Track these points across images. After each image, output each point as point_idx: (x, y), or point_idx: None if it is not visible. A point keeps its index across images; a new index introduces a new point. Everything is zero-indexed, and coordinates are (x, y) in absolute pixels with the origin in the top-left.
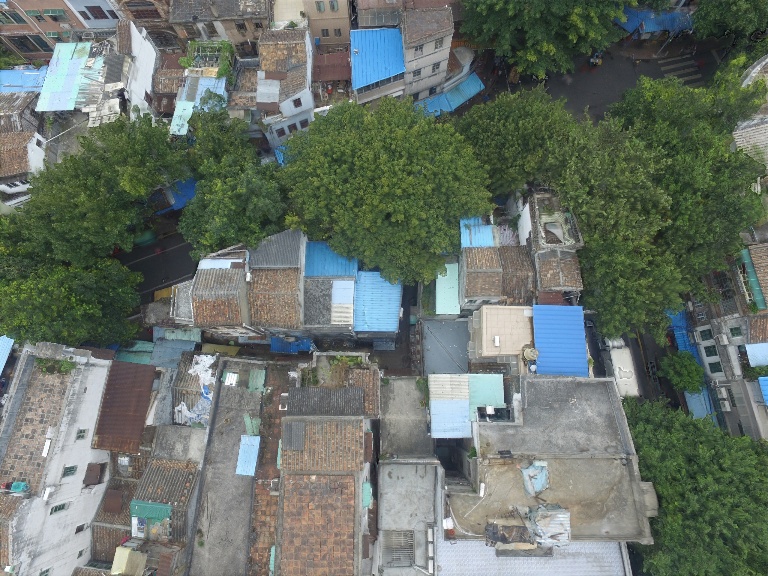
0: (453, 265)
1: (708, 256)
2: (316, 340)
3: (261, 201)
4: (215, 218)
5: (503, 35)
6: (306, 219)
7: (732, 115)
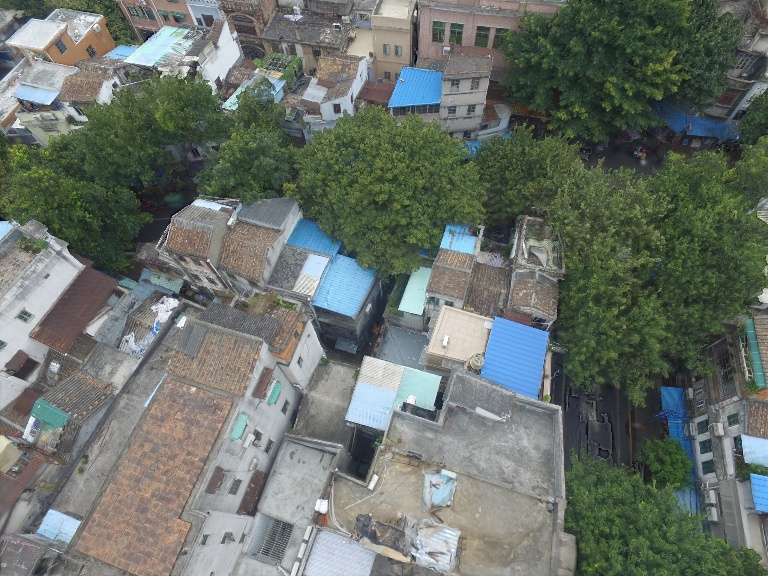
0: (430, 269)
1: (702, 314)
2: None
3: (266, 159)
4: None
5: (538, 91)
6: (304, 193)
7: (755, 189)
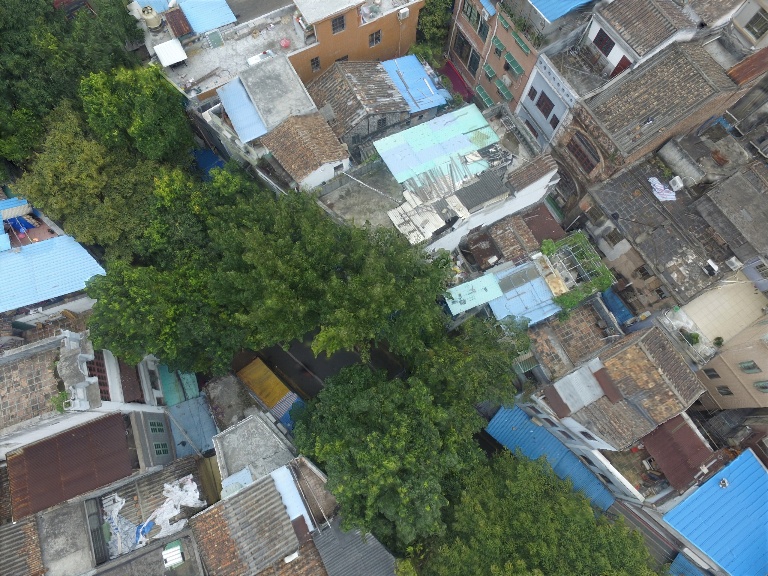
0: None
1: None
2: None
3: (405, 529)
4: (344, 478)
5: None
6: None
7: None
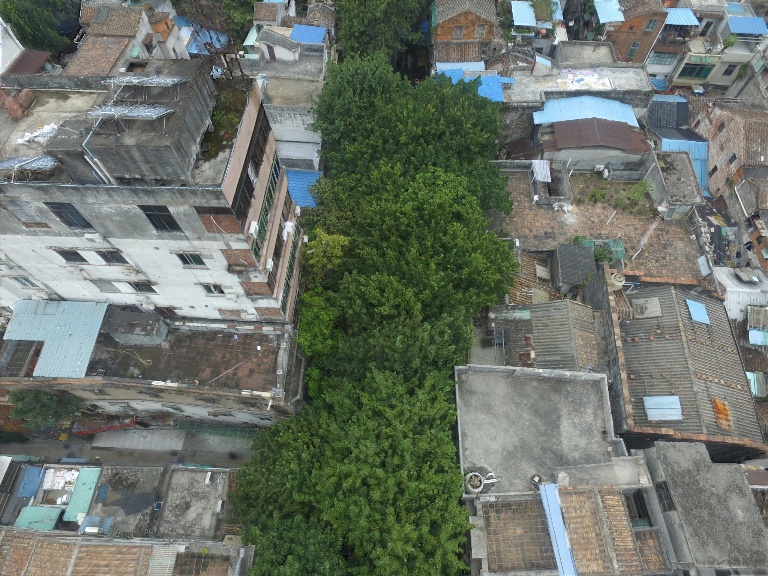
0: None
1: None
2: None
3: None
4: None
5: None
6: None
7: None
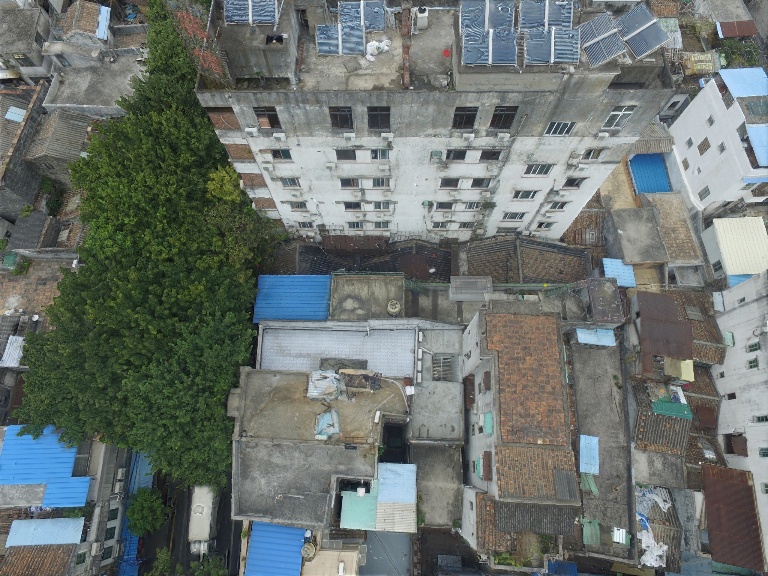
0: None
1: None
2: (527, 574)
3: None
4: None
5: None
6: None
7: None
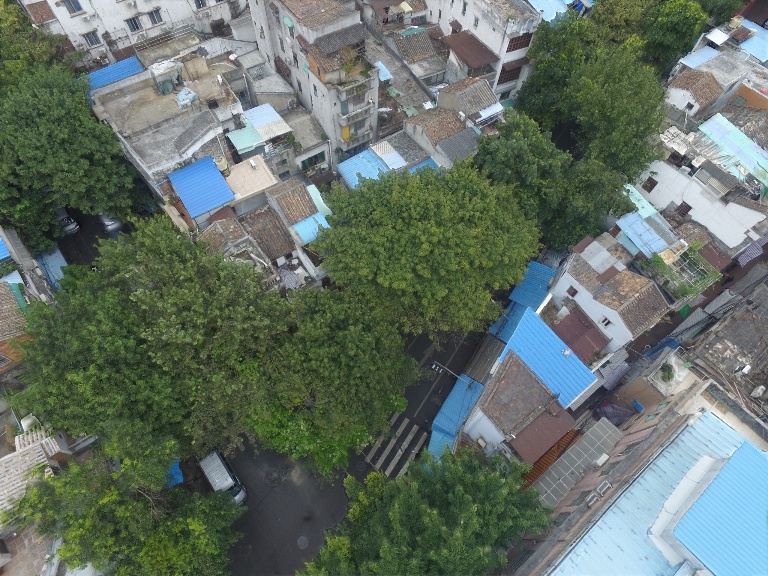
0: None
1: None
2: None
3: None
4: None
5: None
6: None
7: None
